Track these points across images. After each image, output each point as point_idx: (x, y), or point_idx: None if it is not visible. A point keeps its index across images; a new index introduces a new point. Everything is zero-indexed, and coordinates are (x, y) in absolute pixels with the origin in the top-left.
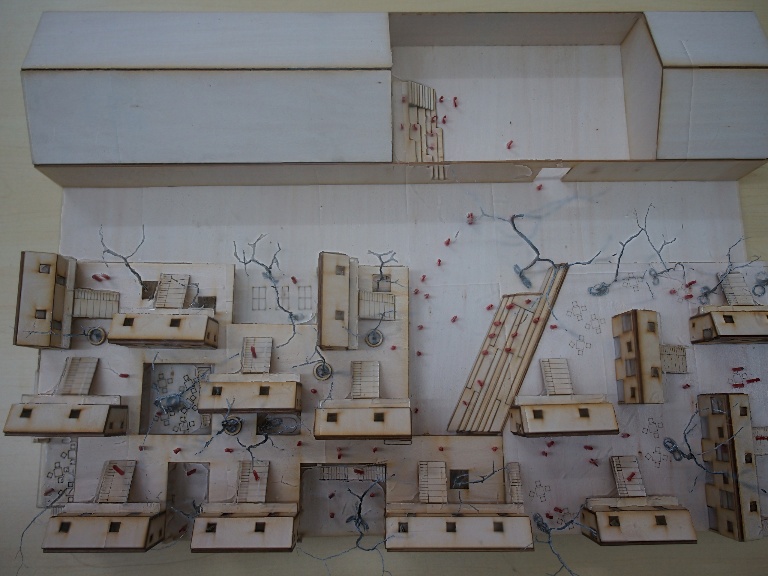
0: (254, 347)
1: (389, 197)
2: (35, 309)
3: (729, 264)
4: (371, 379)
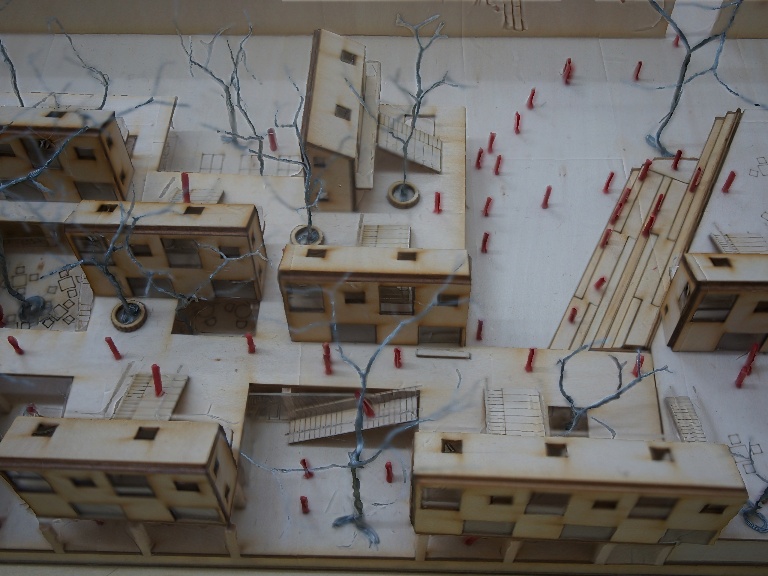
0: None
1: (435, 51)
2: None
3: None
4: (395, 241)
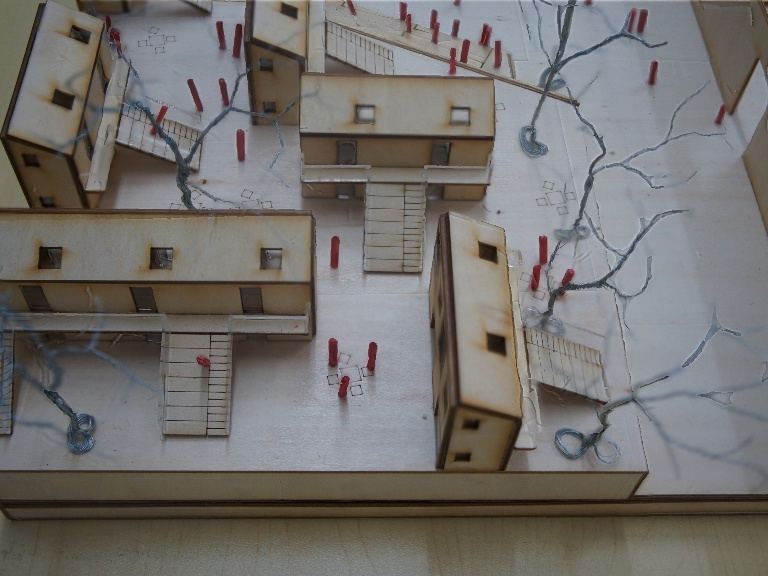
0: None
1: None
2: None
3: (622, 251)
4: None
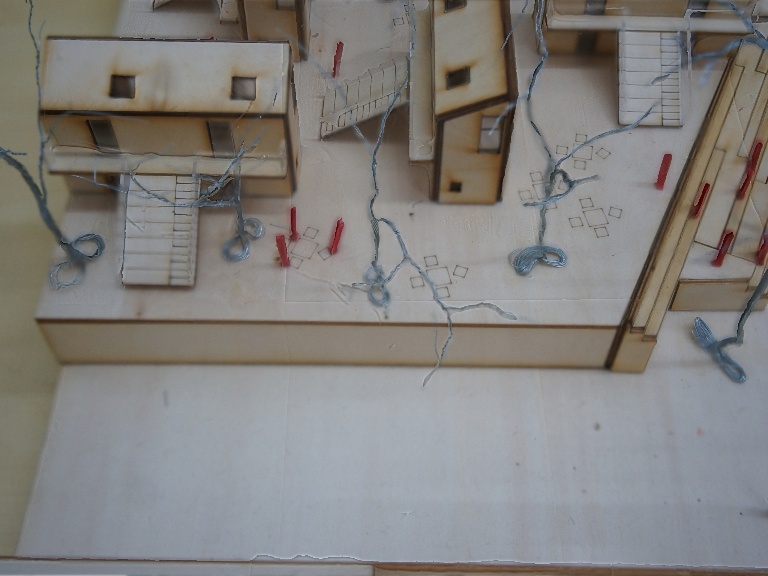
0: None
1: None
2: None
3: None
4: None
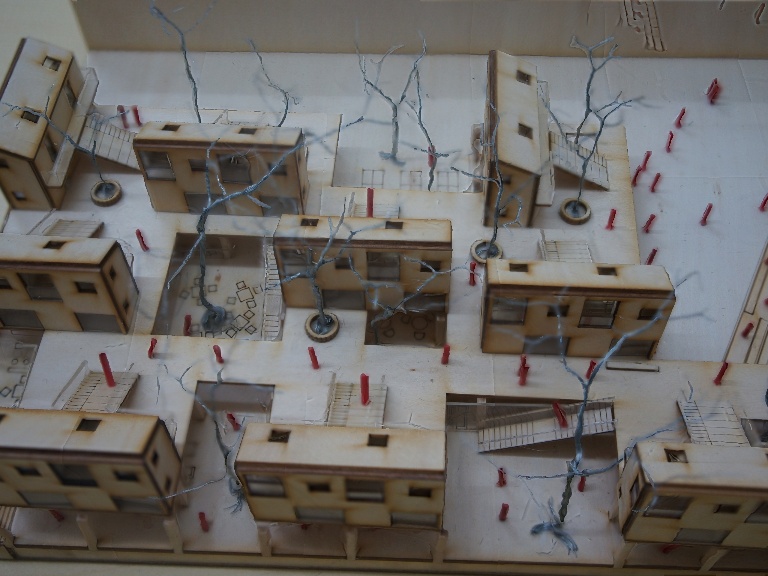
0: (372, 194)
1: (579, 70)
2: (24, 106)
3: None
4: (577, 256)
